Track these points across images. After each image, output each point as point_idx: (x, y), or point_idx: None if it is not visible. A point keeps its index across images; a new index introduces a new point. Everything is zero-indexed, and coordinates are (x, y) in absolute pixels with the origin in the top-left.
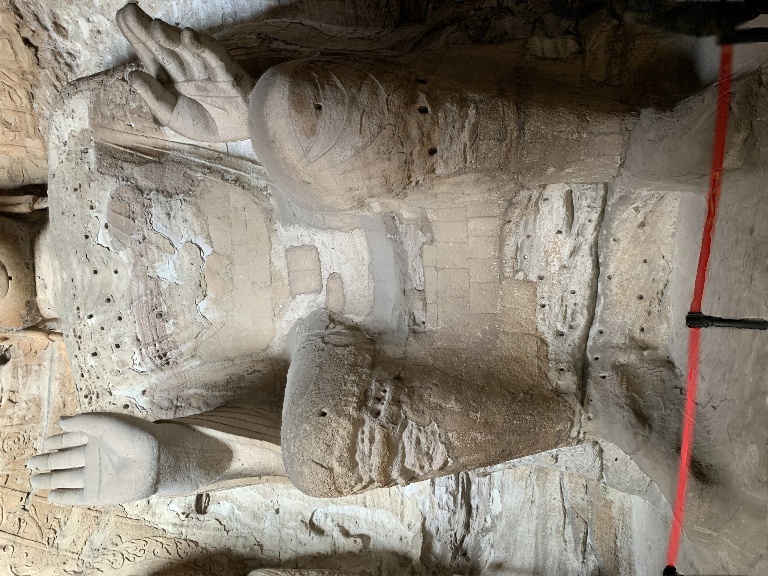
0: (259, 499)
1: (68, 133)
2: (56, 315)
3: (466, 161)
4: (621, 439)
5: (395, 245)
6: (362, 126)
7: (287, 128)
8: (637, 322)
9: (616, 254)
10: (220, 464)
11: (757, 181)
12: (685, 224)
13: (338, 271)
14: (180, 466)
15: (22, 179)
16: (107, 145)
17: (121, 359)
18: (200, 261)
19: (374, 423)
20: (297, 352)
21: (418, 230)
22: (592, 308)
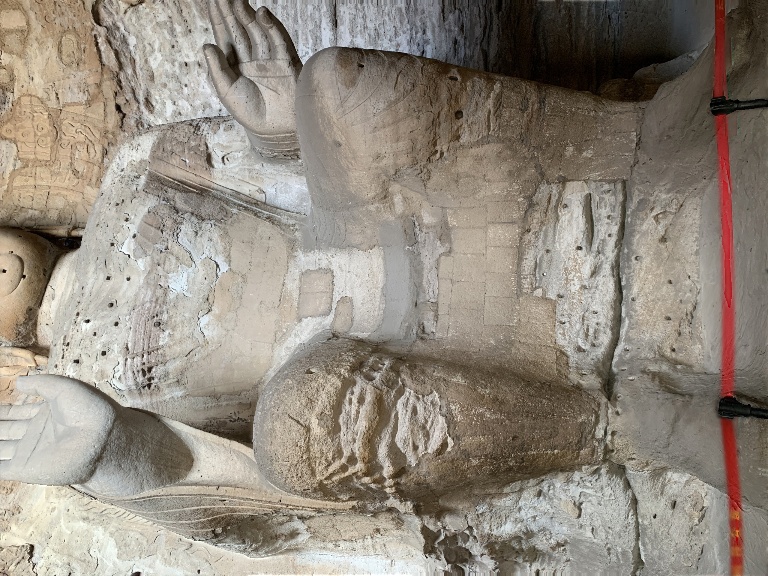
0: None
1: (128, 162)
2: (51, 337)
3: (489, 129)
4: (657, 423)
5: (412, 257)
6: (397, 83)
7: (330, 78)
8: (667, 341)
9: (639, 274)
10: (176, 469)
11: (767, 73)
12: (708, 231)
13: (350, 295)
14: (131, 450)
15: (69, 222)
16: (159, 175)
17: (102, 369)
18: (214, 276)
19: (367, 384)
20: (293, 355)
21: (437, 239)
22: (616, 330)
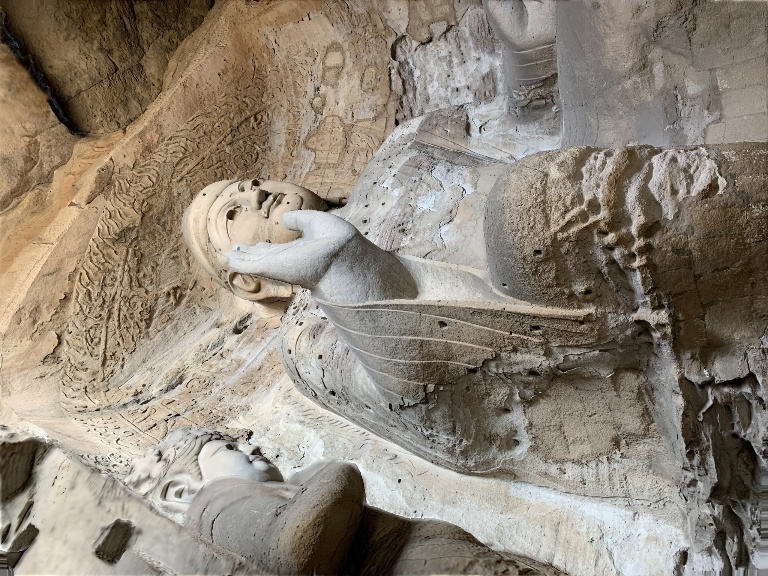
0: (400, 502)
1: (399, 136)
2: None
3: None
4: None
5: (673, 134)
6: None
7: None
8: None
9: None
10: (400, 292)
11: None
12: None
13: None
14: (364, 260)
15: None
16: (422, 143)
17: None
18: (460, 197)
19: None
20: None
21: (704, 110)
22: None
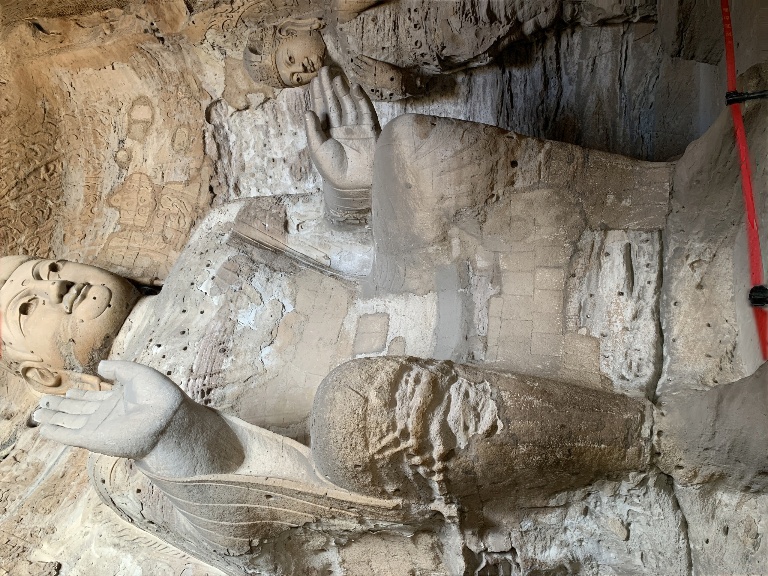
0: None
1: (216, 223)
2: None
3: (540, 177)
4: (702, 414)
5: (465, 298)
6: (463, 137)
7: (408, 131)
8: (709, 373)
9: (678, 318)
10: (228, 460)
11: None
12: (741, 277)
13: (403, 335)
14: (191, 432)
15: None
16: (241, 235)
17: None
18: (279, 315)
19: (423, 370)
20: None
21: (488, 282)
22: (659, 367)
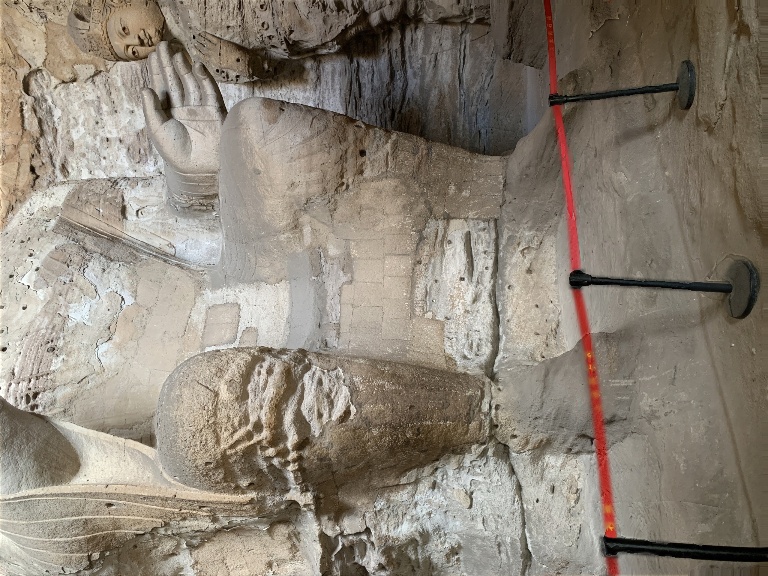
0: None
1: (39, 207)
2: None
3: (388, 167)
4: (532, 387)
5: (317, 286)
6: (312, 124)
7: (255, 115)
8: (537, 350)
9: (512, 300)
10: (60, 471)
11: (589, 113)
12: (562, 262)
13: (255, 325)
14: (13, 443)
15: None
16: (70, 221)
17: None
18: (118, 308)
19: (275, 360)
20: None
21: (340, 270)
22: (496, 345)
